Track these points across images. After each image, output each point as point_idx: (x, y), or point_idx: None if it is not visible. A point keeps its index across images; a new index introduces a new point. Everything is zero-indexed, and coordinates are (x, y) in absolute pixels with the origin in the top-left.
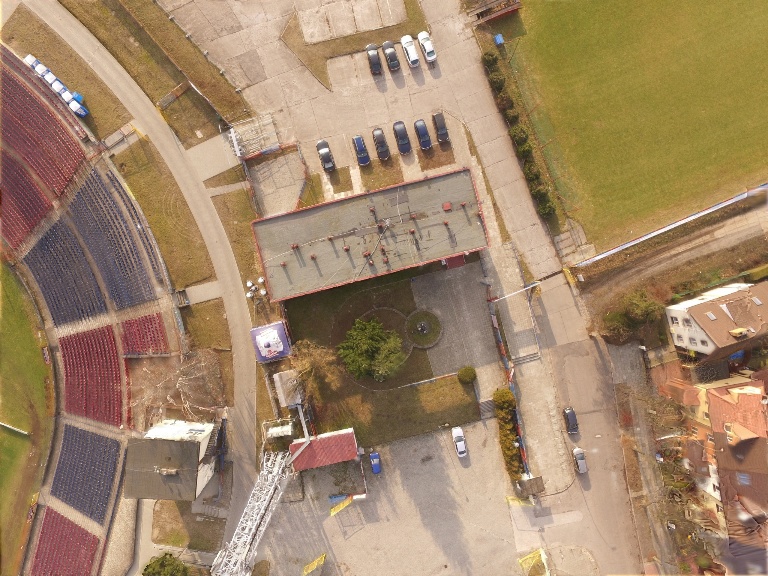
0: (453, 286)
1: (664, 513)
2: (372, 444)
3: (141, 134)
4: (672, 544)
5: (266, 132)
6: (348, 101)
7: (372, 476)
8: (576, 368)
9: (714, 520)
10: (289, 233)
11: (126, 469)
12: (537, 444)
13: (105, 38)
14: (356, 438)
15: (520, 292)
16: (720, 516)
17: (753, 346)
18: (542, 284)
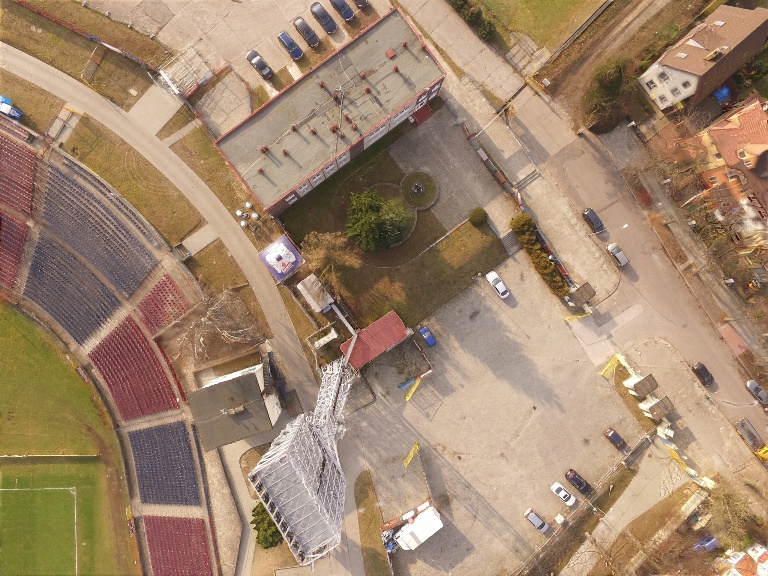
0: (430, 139)
1: (714, 250)
2: (417, 321)
3: (79, 114)
4: (737, 300)
5: (195, 65)
6: (259, 5)
7: (430, 351)
8: (578, 171)
9: (762, 226)
10: (254, 139)
11: (196, 424)
12: (571, 257)
13: (8, 37)
14: (399, 317)
15: (495, 119)
16: (766, 221)
17: (735, 80)
18: (513, 104)
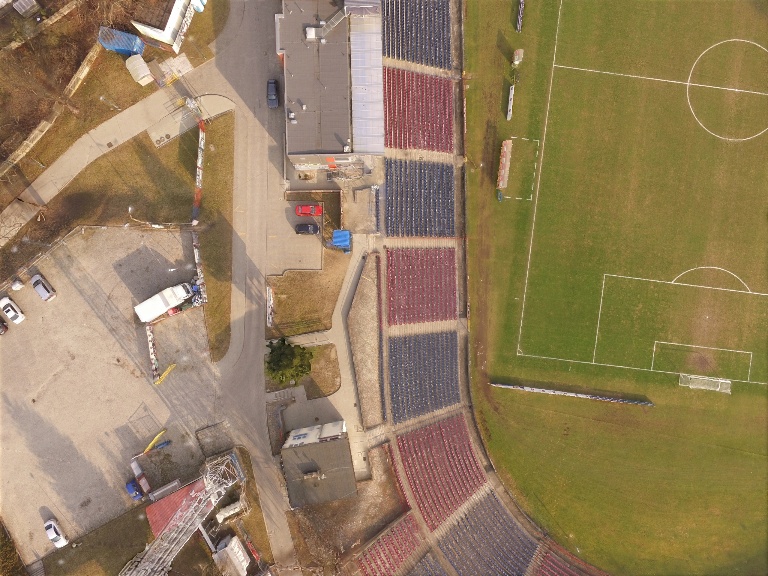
0: None
1: None
2: (144, 505)
3: None
4: None
5: None
6: None
7: None
8: None
9: None
10: None
11: (352, 467)
12: None
13: None
14: None
15: None
16: None
17: None
18: None
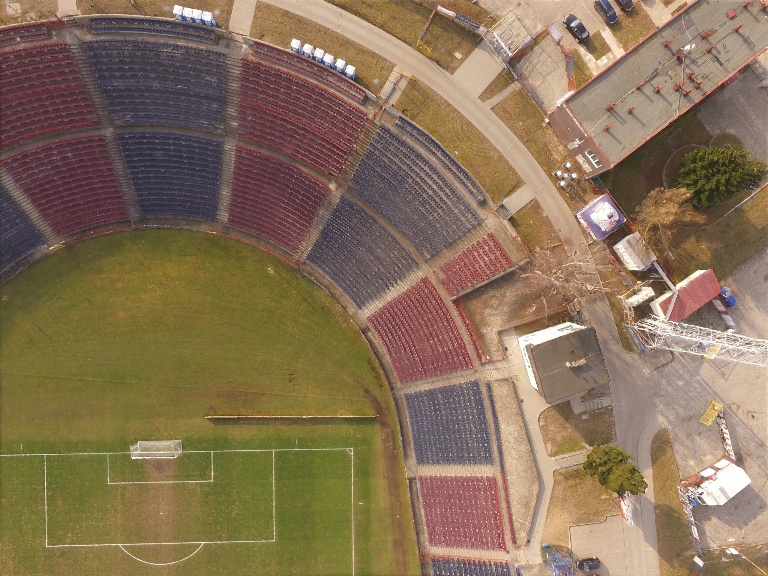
0: (735, 102)
1: None
2: None
3: (408, 76)
4: None
5: (514, 29)
6: None
7: None
8: None
9: None
10: (600, 98)
11: (540, 376)
12: None
13: (342, 2)
14: None
15: None
16: None
17: None
18: None
